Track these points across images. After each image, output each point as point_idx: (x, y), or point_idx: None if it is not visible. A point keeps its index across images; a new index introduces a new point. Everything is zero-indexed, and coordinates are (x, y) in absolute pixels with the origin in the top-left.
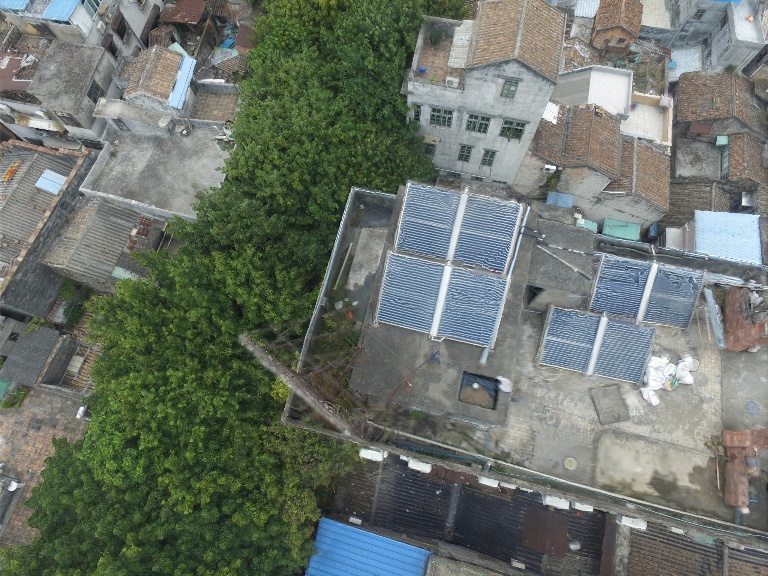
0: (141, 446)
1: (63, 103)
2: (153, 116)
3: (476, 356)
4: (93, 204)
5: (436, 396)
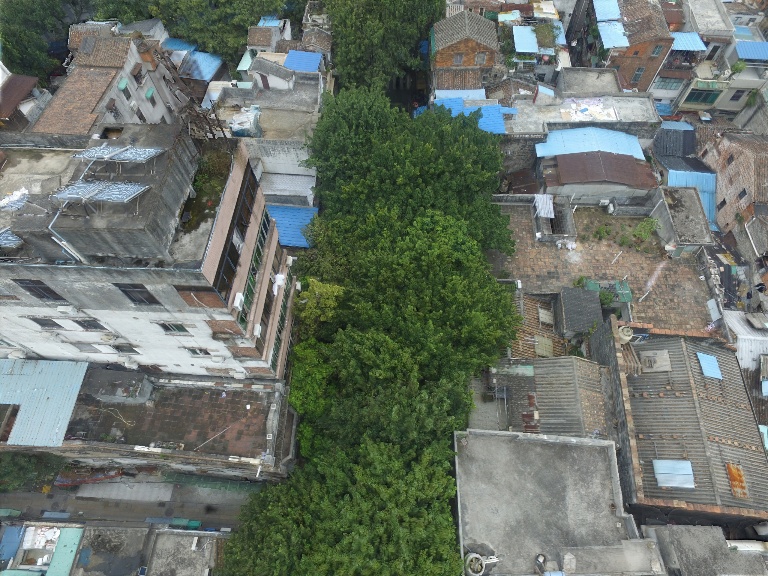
0: (415, 223)
1: (696, 540)
2: (586, 567)
3: (109, 145)
4: (592, 432)
5: (135, 127)
